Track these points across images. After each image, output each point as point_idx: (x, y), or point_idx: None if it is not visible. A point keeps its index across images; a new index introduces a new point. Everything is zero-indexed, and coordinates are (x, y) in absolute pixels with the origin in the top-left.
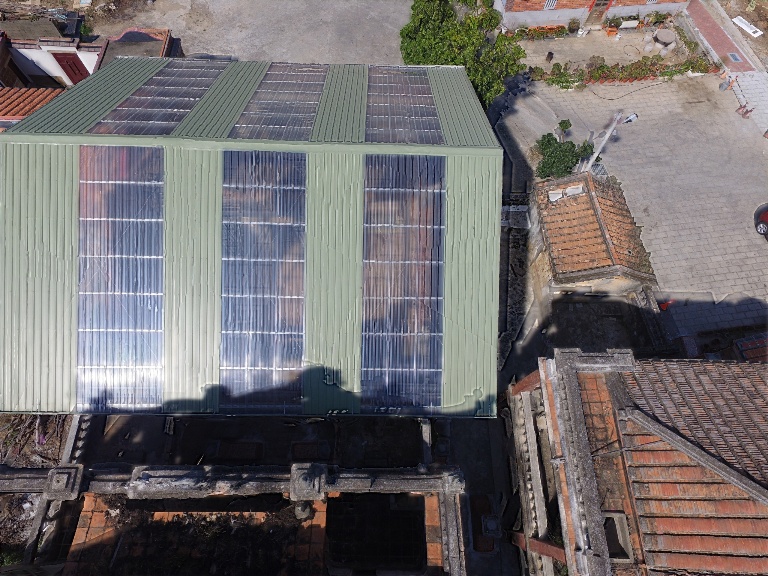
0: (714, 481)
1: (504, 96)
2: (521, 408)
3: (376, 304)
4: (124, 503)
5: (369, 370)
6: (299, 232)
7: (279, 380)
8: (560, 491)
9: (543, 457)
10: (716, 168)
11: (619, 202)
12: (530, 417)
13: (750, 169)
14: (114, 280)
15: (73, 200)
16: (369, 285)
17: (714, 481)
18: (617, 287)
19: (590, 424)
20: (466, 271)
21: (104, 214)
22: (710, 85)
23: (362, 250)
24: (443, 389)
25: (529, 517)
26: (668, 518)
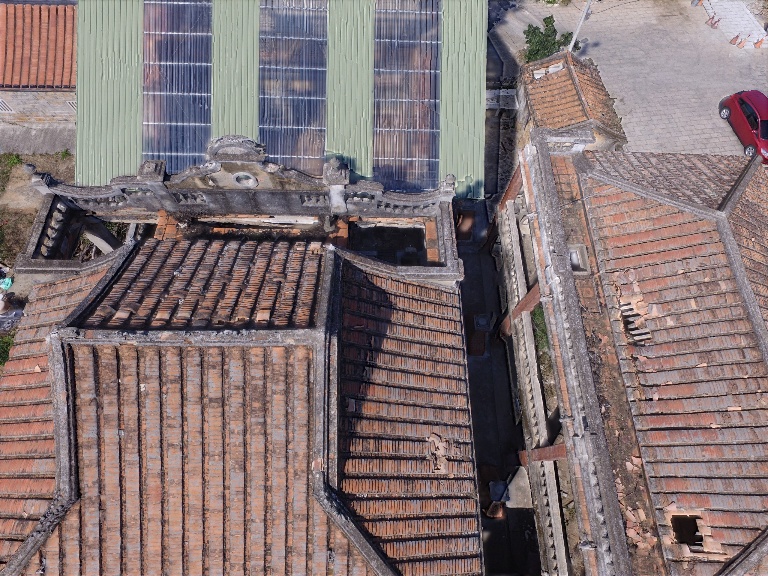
0: (653, 206)
1: (496, 11)
2: (507, 217)
3: (385, 105)
4: (190, 220)
5: (380, 159)
6: (322, 46)
7: (306, 166)
8: (534, 235)
9: (525, 255)
10: (686, 68)
11: (595, 78)
12: (513, 218)
13: (716, 69)
14: (172, 83)
15: (139, 17)
16: (379, 89)
17: (653, 206)
18: (593, 148)
19: (559, 189)
20: (459, 79)
21: (164, 29)
22: (683, 2)
23: (374, 60)
24: (440, 175)
25: (513, 296)
26: (617, 237)
